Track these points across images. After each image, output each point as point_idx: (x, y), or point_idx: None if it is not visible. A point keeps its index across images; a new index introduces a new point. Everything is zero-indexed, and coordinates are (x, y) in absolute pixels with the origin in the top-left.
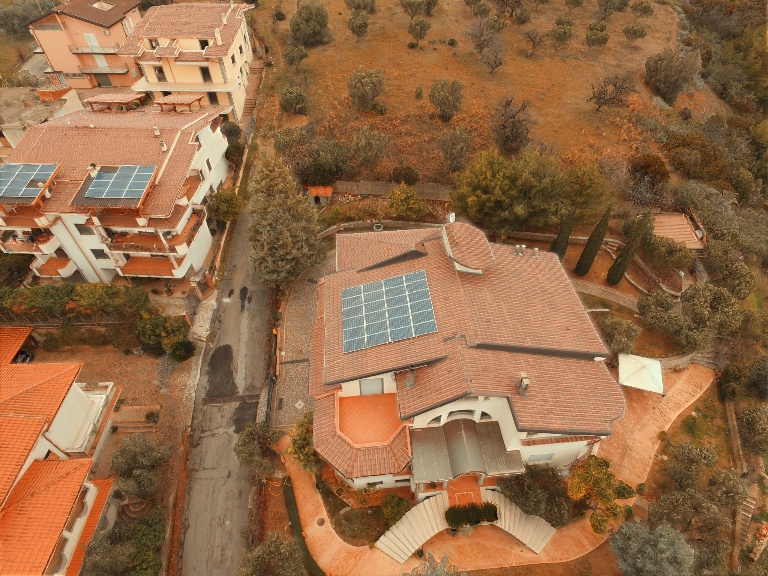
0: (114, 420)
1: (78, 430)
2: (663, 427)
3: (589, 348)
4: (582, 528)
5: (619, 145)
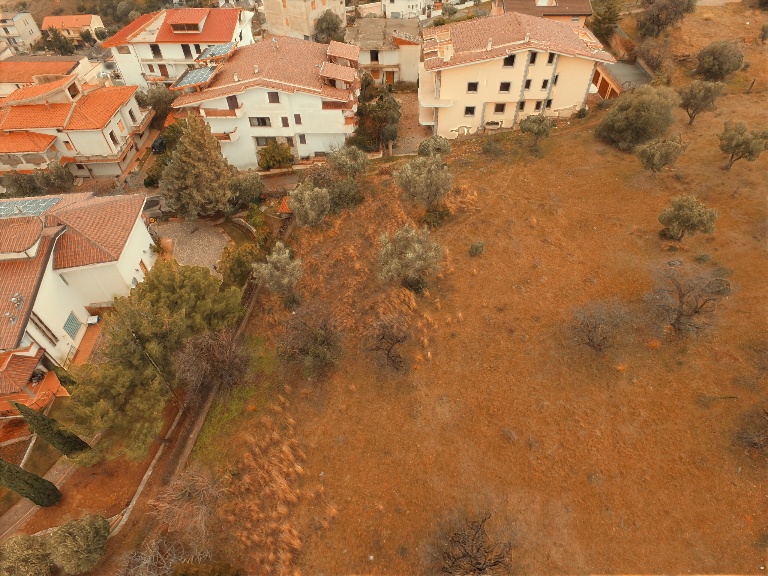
0: (123, 175)
1: (93, 153)
2: None
3: None
4: None
5: None
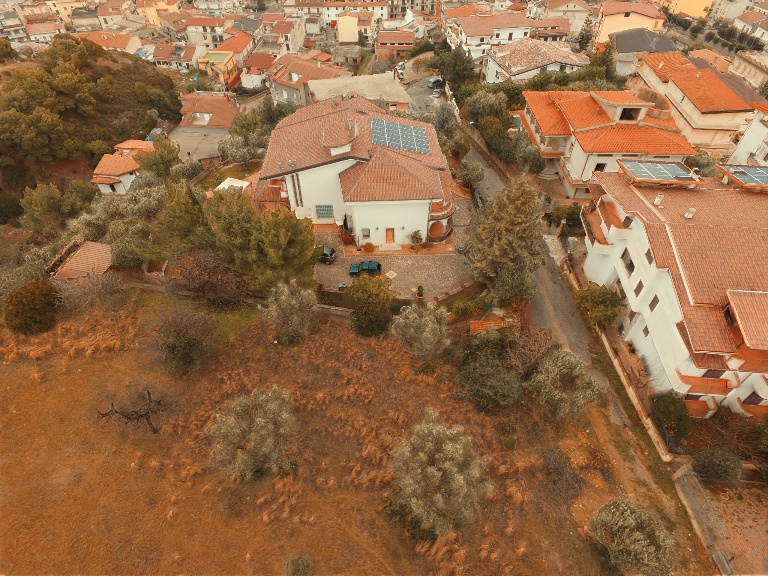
0: (571, 200)
1: None
2: None
3: None
4: None
5: None
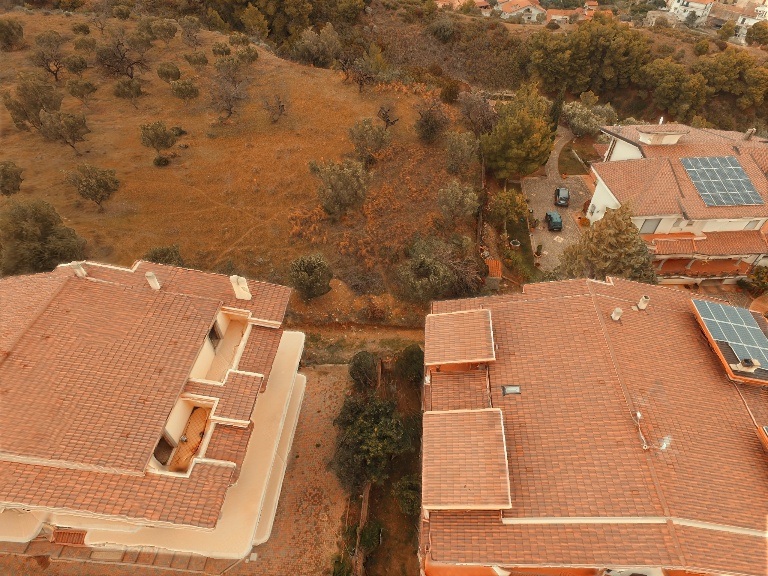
0: None
1: None
2: None
3: None
4: None
5: (411, 97)
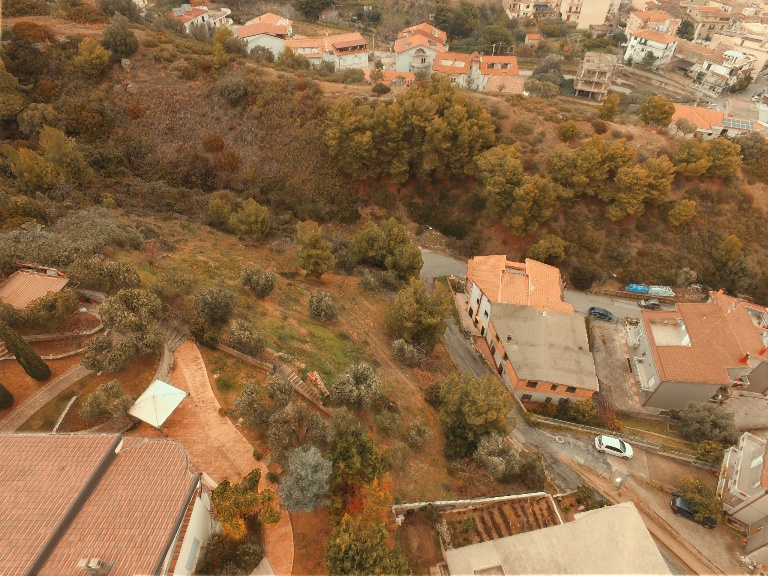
0: None
1: None
2: (216, 407)
3: (100, 454)
4: (271, 528)
5: None
